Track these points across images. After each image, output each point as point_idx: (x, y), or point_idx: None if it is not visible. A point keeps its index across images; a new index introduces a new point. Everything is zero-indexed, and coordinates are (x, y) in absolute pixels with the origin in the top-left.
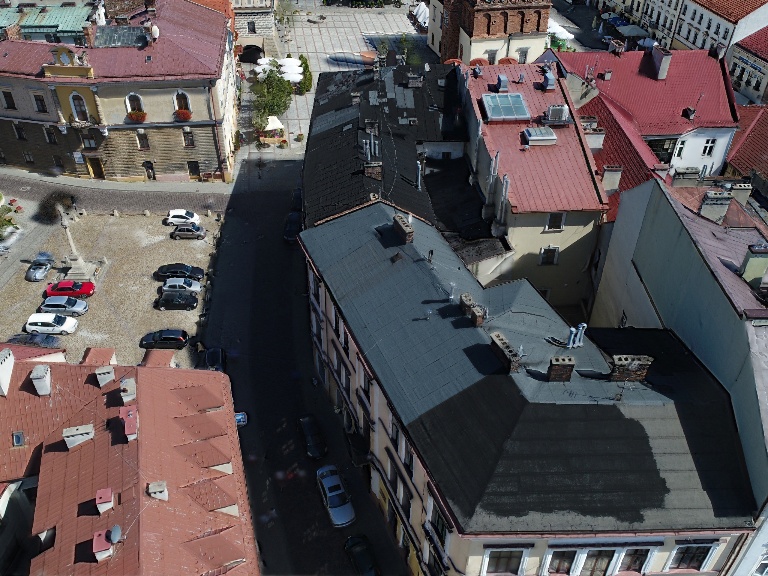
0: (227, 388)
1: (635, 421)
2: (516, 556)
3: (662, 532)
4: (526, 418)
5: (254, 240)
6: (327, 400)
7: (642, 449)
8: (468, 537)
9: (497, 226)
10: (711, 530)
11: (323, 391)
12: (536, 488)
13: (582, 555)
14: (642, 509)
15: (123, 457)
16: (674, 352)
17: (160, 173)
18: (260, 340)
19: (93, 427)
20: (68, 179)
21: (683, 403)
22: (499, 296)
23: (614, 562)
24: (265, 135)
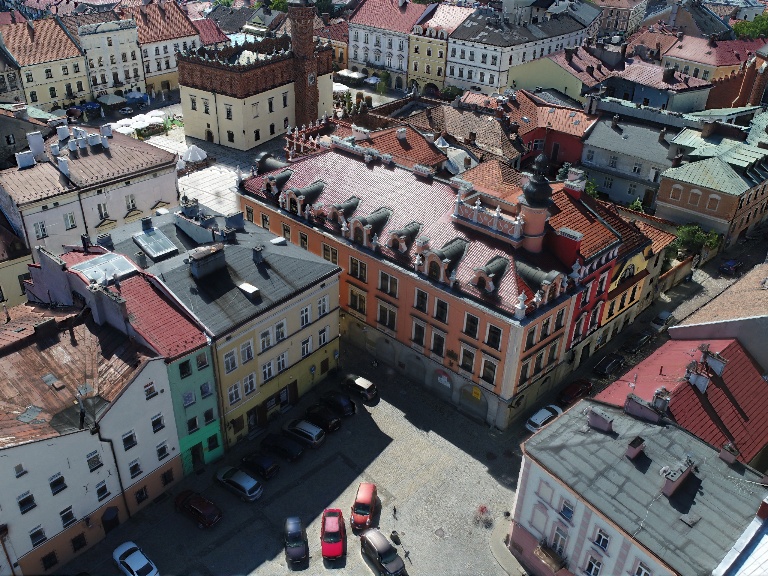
0: None
1: None
2: None
3: None
4: None
5: None
6: None
7: None
8: None
9: None
10: None
11: None
12: None
13: None
14: None
15: None
16: (540, 1)
17: None
18: None
19: (660, 33)
20: None
21: None
22: (559, 9)
23: None
24: None
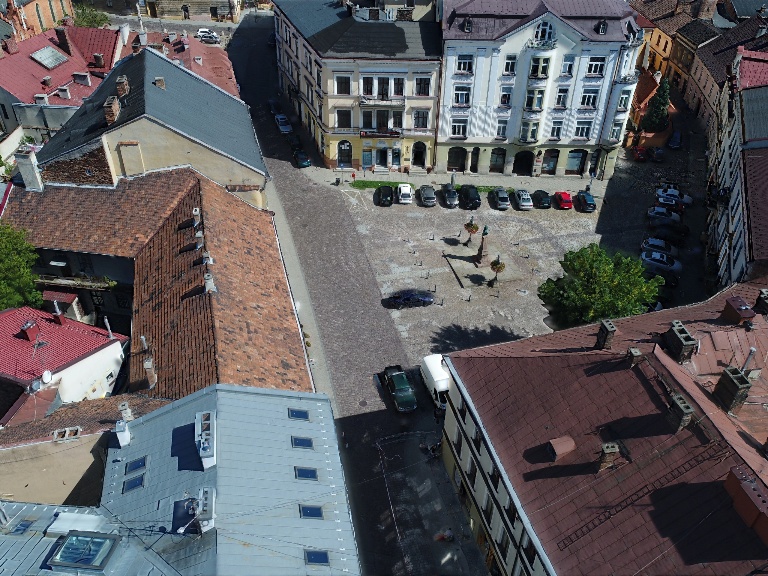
0: (230, 63)
1: (401, 28)
2: (348, 82)
3: (403, 60)
4: (355, 26)
5: (250, 46)
6: (285, 99)
7: (401, 36)
8: (324, 59)
9: (380, 6)
10: (423, 60)
11: (283, 96)
12: (354, 46)
13: (375, 81)
14: (396, 53)
15: (183, 54)
16: None
17: (192, 14)
18: (250, 80)
19: (168, 49)
20: (134, 17)
21: (423, 23)
22: None
23: (390, 86)
24: (261, 3)
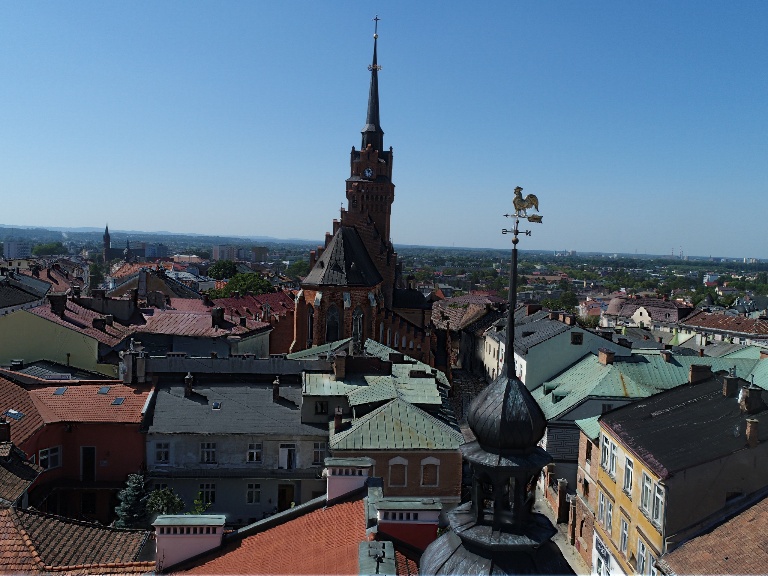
0: None
1: None
2: None
3: None
4: None
5: None
6: None
7: None
8: None
9: None
10: None
11: None
12: None
13: None
14: None
15: None
16: None
17: None
18: None
19: None
20: None
21: None
22: None
23: None
24: None
